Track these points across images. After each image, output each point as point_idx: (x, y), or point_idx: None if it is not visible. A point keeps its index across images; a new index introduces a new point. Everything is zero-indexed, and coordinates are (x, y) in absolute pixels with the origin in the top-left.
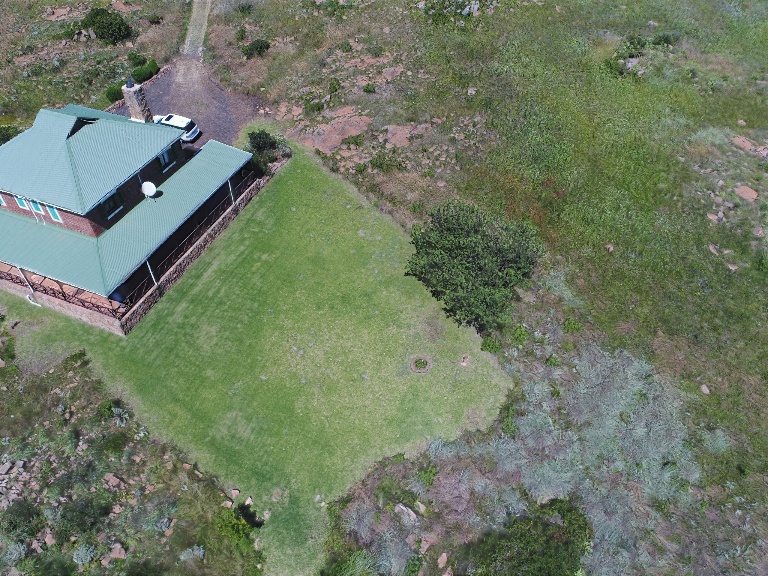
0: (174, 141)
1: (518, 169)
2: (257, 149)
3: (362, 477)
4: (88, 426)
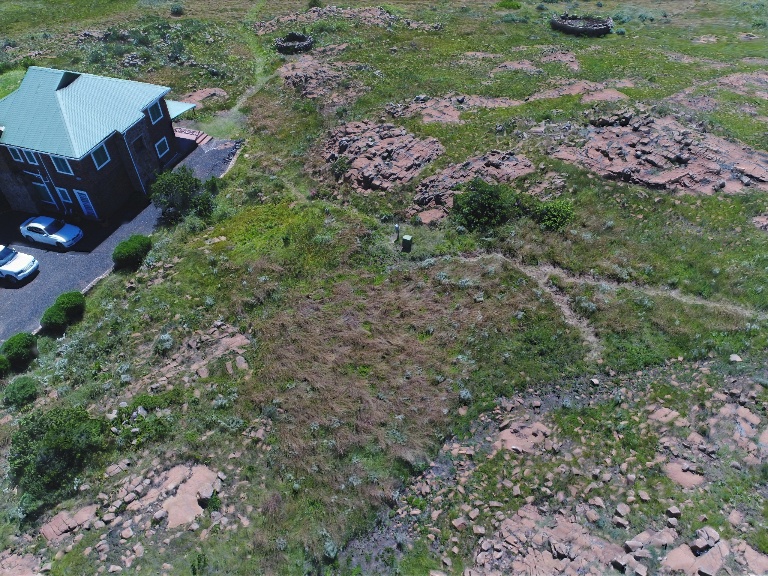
0: None
1: None
2: None
3: None
4: None
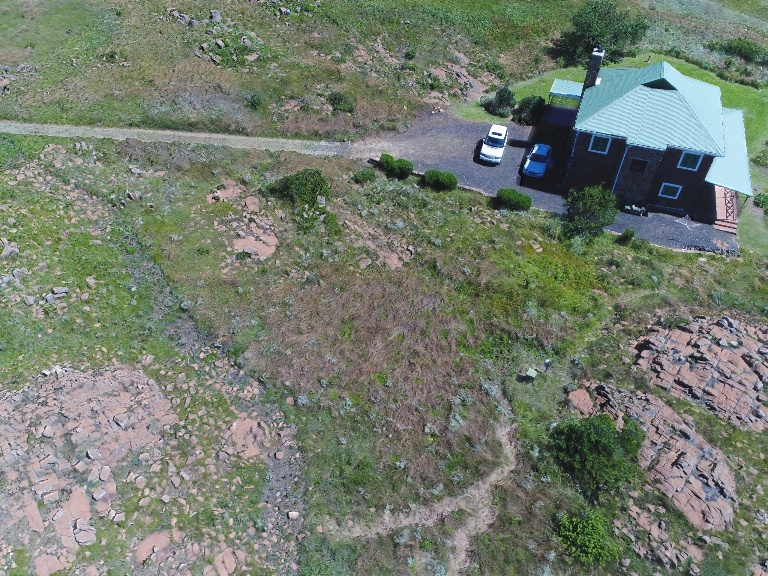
0: None
1: None
2: None
3: None
4: None
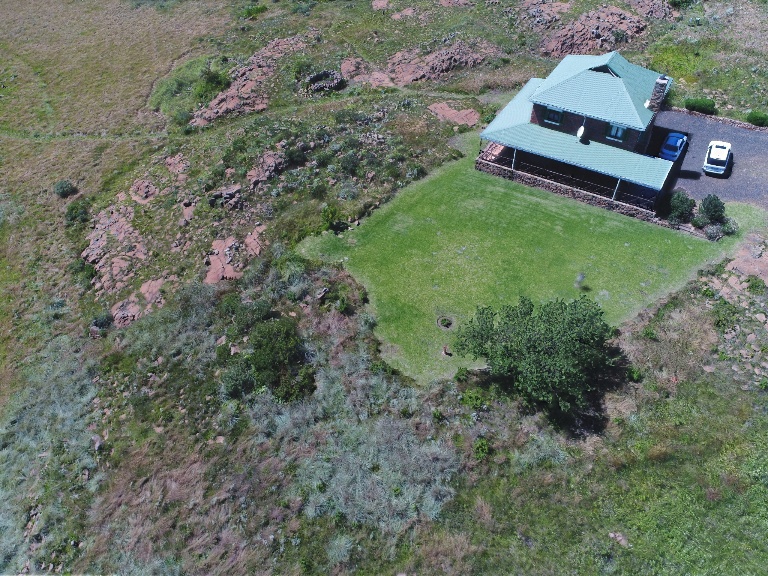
0: (628, 125)
1: (761, 454)
2: (704, 210)
3: (356, 280)
4: (407, 163)
